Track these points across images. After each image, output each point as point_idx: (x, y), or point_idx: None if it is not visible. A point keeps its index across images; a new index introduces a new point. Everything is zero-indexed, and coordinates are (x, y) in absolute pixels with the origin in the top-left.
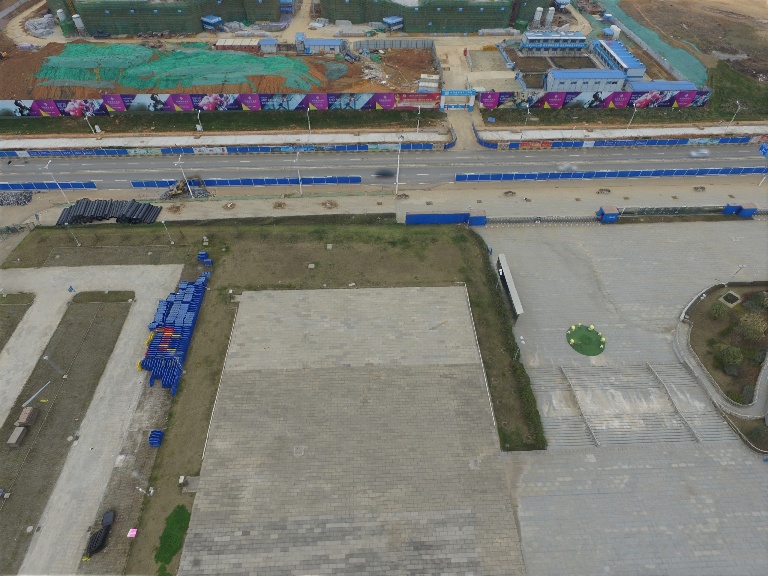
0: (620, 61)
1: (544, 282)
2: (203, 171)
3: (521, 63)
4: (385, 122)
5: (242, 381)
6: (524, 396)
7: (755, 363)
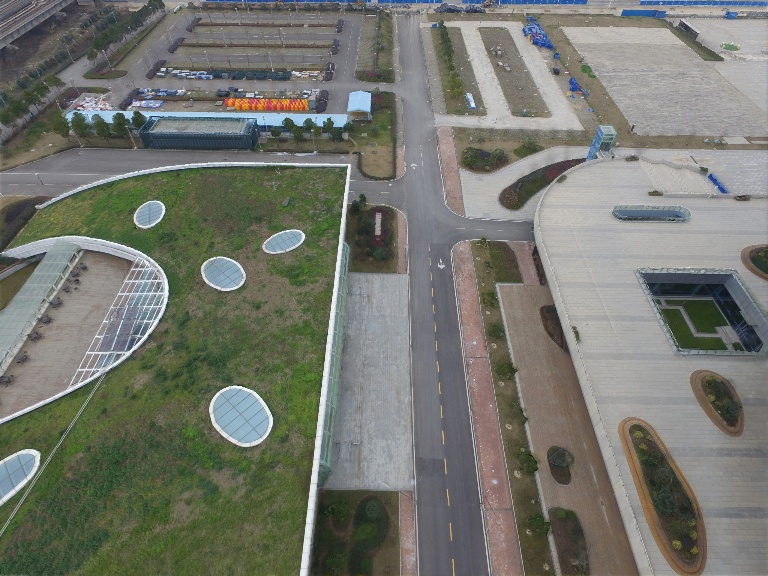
0: None
1: (703, 33)
2: None
3: None
4: None
5: None
6: (710, 51)
7: None
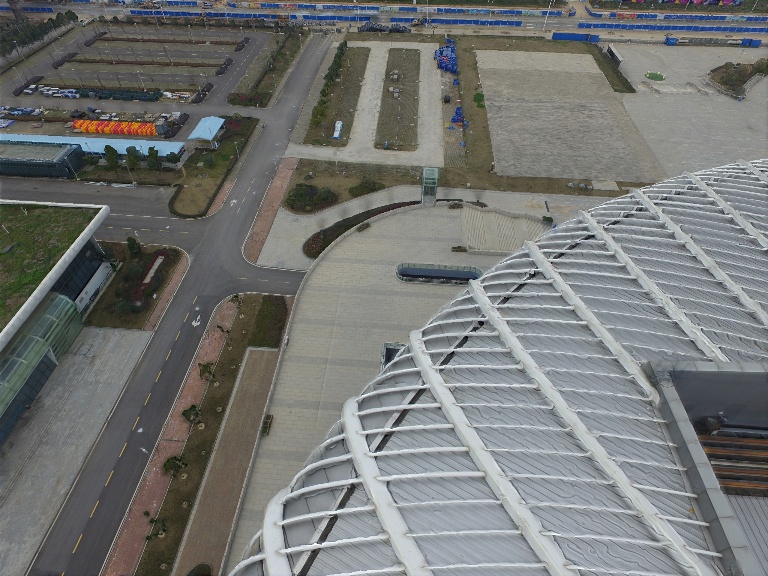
0: None
1: (633, 61)
2: None
3: None
4: (529, 5)
5: (489, 70)
6: (625, 81)
7: (743, 82)
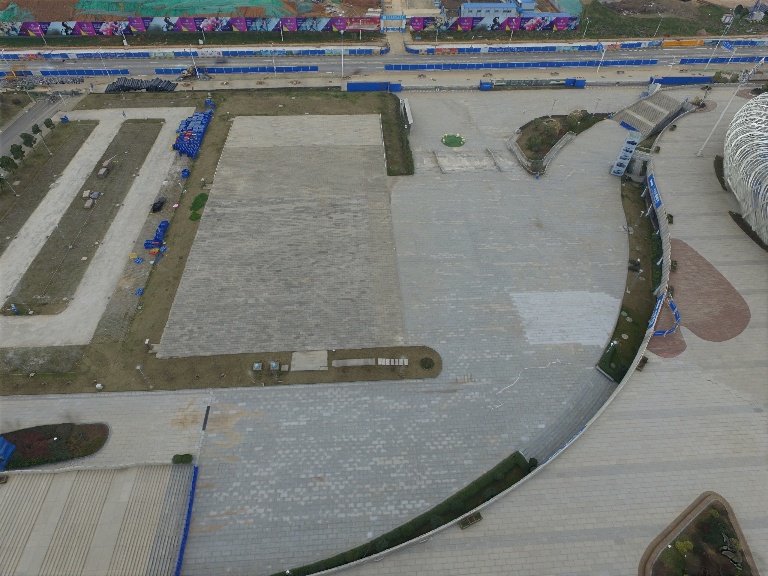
0: None
1: (434, 117)
2: (205, 66)
3: (447, 4)
4: (339, 39)
5: (236, 151)
6: (405, 156)
7: (550, 145)
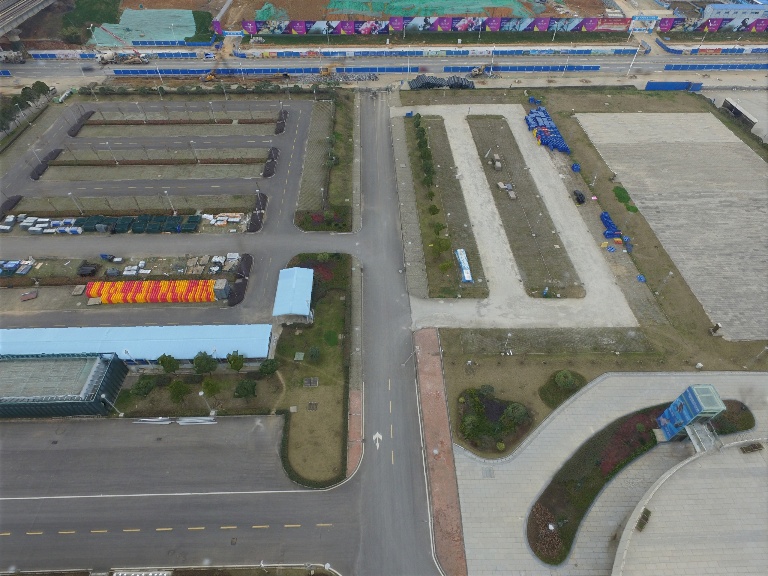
0: (755, 0)
1: (755, 116)
2: None
3: (671, 5)
4: (590, 39)
5: (608, 147)
6: None
7: None
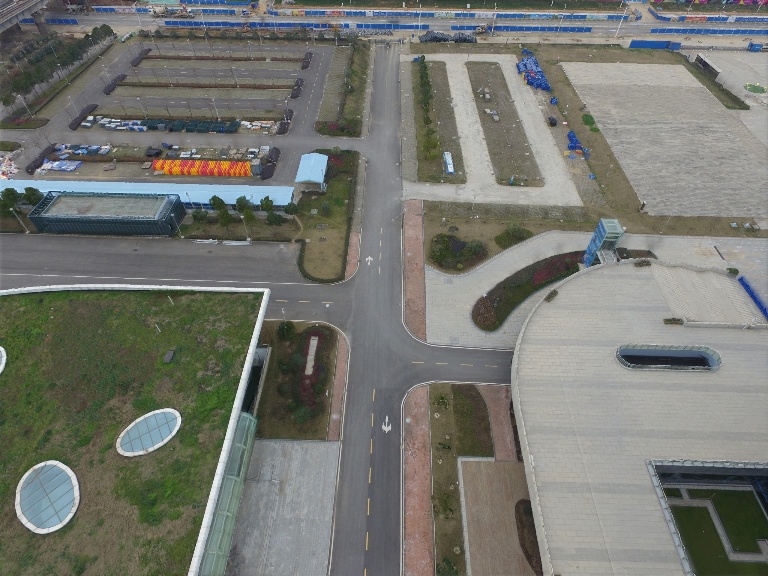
0: None
1: (724, 70)
2: None
3: None
4: (588, 8)
5: (585, 86)
6: (733, 96)
7: None
